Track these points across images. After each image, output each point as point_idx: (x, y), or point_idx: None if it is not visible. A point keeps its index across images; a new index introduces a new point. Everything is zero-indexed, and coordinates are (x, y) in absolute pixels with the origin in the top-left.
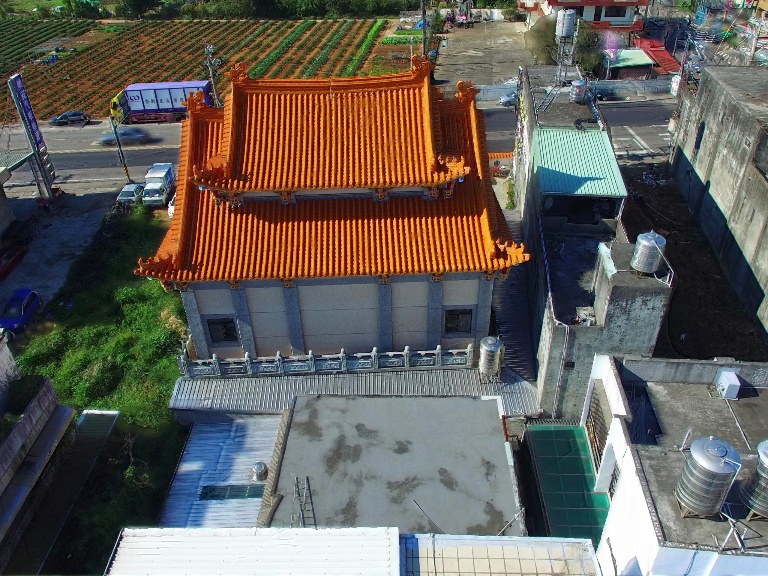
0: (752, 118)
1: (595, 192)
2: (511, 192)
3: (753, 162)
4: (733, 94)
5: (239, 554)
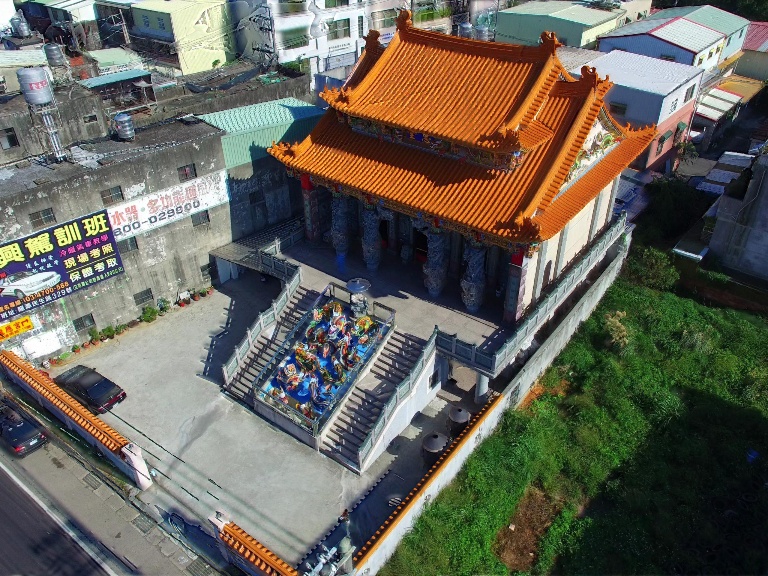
0: (76, 101)
1: (304, 103)
2: (110, 329)
3: (109, 125)
4: (3, 115)
5: (625, 81)
